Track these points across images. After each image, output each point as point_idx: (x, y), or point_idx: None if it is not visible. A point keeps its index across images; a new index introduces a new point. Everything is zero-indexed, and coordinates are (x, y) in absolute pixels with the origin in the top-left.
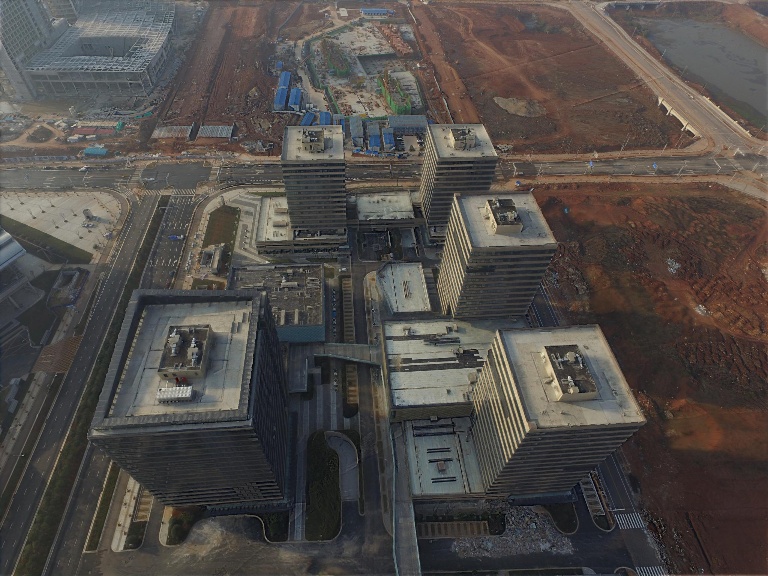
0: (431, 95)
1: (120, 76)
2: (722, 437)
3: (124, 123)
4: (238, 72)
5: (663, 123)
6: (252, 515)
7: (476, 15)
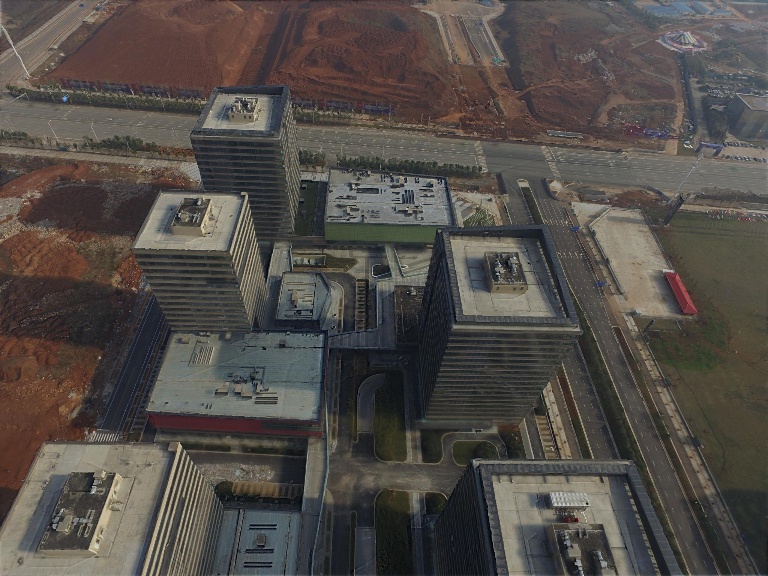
0: None
1: None
2: None
3: None
4: None
5: None
6: None
7: None
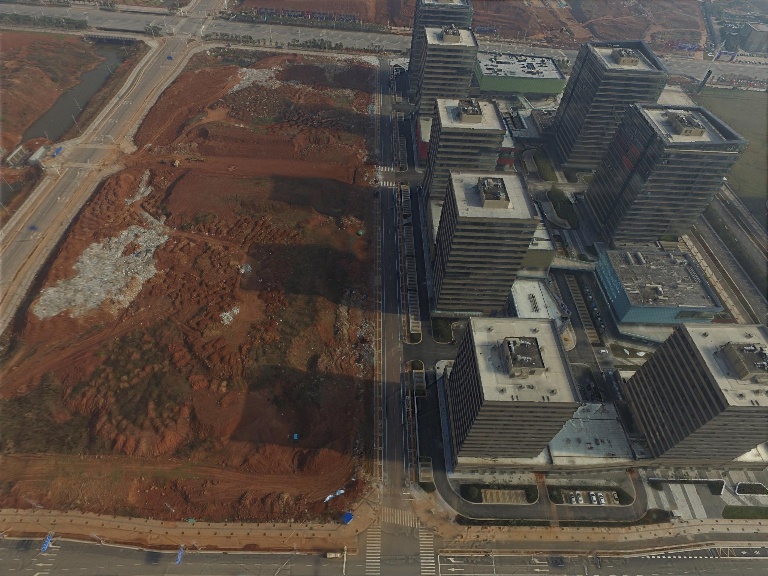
0: None
1: None
2: (315, 193)
3: None
4: None
5: None
6: None
7: None
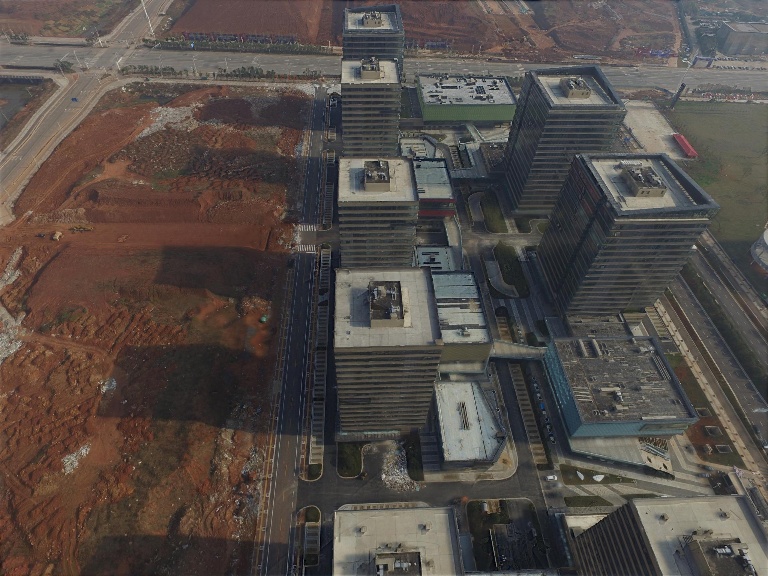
0: None
1: None
2: (211, 271)
3: None
4: None
5: None
6: None
7: None
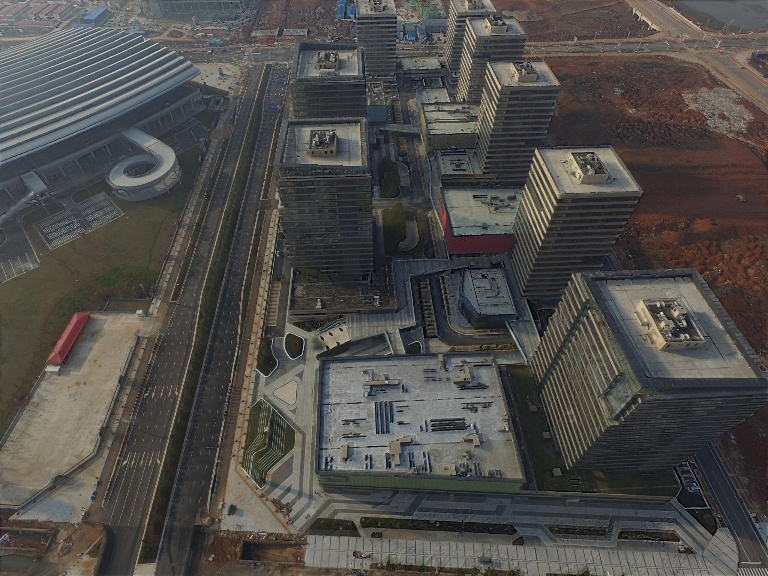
0: None
1: None
2: (630, 158)
3: (230, 28)
4: None
5: (634, 25)
6: None
7: None
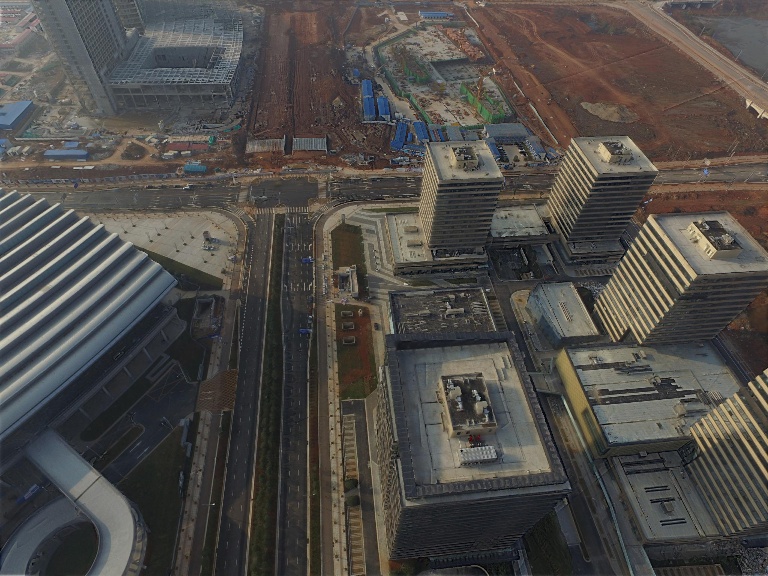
0: (516, 101)
1: (203, 88)
2: None
3: (215, 137)
4: (314, 81)
5: (757, 126)
6: (473, 565)
7: (537, 17)
